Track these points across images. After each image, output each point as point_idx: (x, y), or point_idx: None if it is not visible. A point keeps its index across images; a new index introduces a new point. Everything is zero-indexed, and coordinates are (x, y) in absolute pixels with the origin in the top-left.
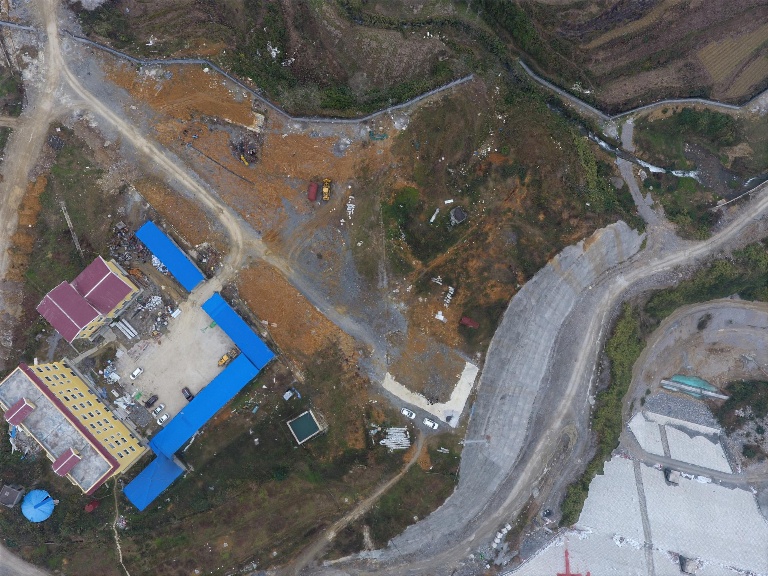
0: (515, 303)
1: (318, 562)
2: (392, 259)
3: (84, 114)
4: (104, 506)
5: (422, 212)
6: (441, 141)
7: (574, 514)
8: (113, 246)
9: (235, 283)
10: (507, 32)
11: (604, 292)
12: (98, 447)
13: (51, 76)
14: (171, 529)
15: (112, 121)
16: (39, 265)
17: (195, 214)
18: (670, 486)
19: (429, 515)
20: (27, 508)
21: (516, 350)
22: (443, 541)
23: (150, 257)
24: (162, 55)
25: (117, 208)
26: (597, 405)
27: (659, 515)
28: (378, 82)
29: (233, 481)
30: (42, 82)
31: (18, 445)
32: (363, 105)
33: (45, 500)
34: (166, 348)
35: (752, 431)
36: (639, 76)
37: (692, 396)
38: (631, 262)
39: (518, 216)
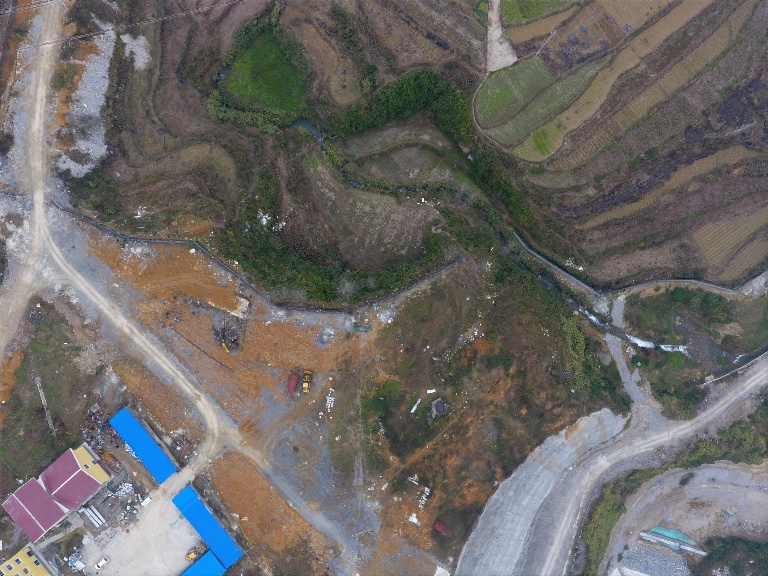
0: (491, 505)
1: None
2: (369, 456)
3: (66, 289)
4: None
5: (403, 403)
6: (427, 331)
7: None
8: (86, 430)
9: (208, 473)
10: (503, 203)
11: (585, 473)
12: None
13: (35, 247)
14: None
15: (94, 298)
16: (10, 442)
17: (172, 399)
18: None
19: None
20: None
21: (491, 542)
22: None
23: (123, 442)
24: (149, 232)
25: (93, 389)
26: None
27: None
28: (369, 248)
29: None
30: (25, 253)
31: None
32: (349, 296)
33: None
34: (134, 537)
35: None
36: (633, 255)
37: (670, 549)
38: (614, 442)
39: (500, 409)
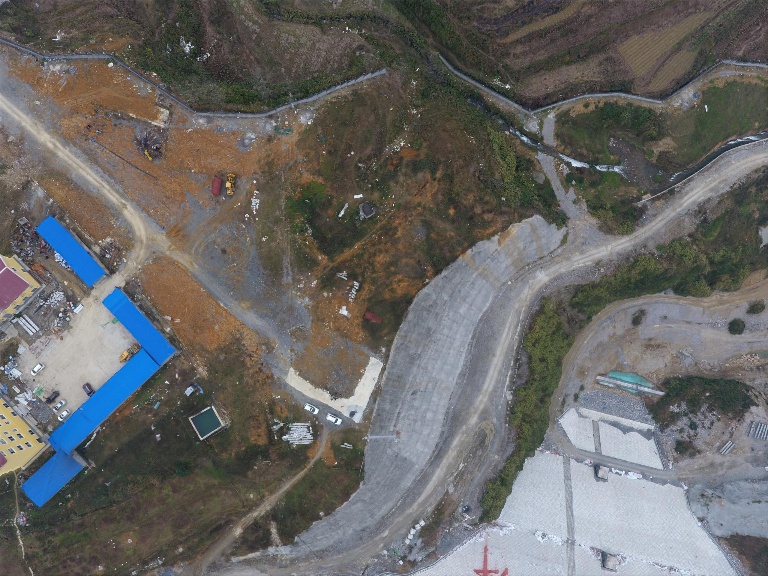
0: (422, 298)
1: (225, 558)
2: (297, 254)
3: None
4: (3, 502)
5: (330, 207)
6: (350, 136)
7: (494, 510)
8: (15, 242)
9: (138, 278)
10: (426, 26)
11: (523, 287)
12: None
13: None
14: (74, 525)
15: (16, 116)
16: None
17: (98, 209)
18: (599, 482)
19: (334, 511)
20: None
21: (428, 345)
22: (355, 537)
23: (53, 253)
24: (67, 50)
25: (20, 204)
26: (514, 400)
27: (585, 511)
28: (296, 77)
29: (133, 477)
30: None
31: None
32: (268, 99)
33: None
34: (68, 344)
35: (685, 427)
36: (559, 70)
37: (629, 392)
38: (552, 257)
39: (428, 211)
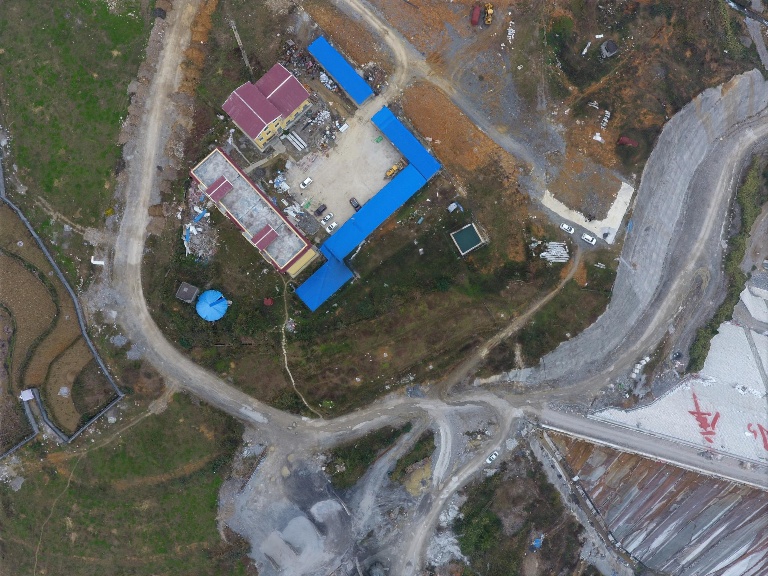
0: (667, 130)
1: (470, 379)
2: (551, 83)
3: None
4: (276, 307)
5: (575, 44)
6: None
7: (702, 359)
8: (284, 62)
9: (400, 101)
10: None
11: (734, 144)
12: (292, 227)
13: None
14: (335, 336)
15: None
16: (210, 81)
17: (361, 35)
18: None
19: (582, 331)
20: (202, 307)
21: (659, 185)
22: (585, 369)
23: (318, 74)
24: None
25: (286, 27)
26: (729, 249)
27: None
28: None
29: (400, 287)
30: None
31: (192, 248)
32: None
33: (219, 300)
34: (334, 161)
35: None
36: None
37: None
38: (759, 117)
39: (665, 53)
